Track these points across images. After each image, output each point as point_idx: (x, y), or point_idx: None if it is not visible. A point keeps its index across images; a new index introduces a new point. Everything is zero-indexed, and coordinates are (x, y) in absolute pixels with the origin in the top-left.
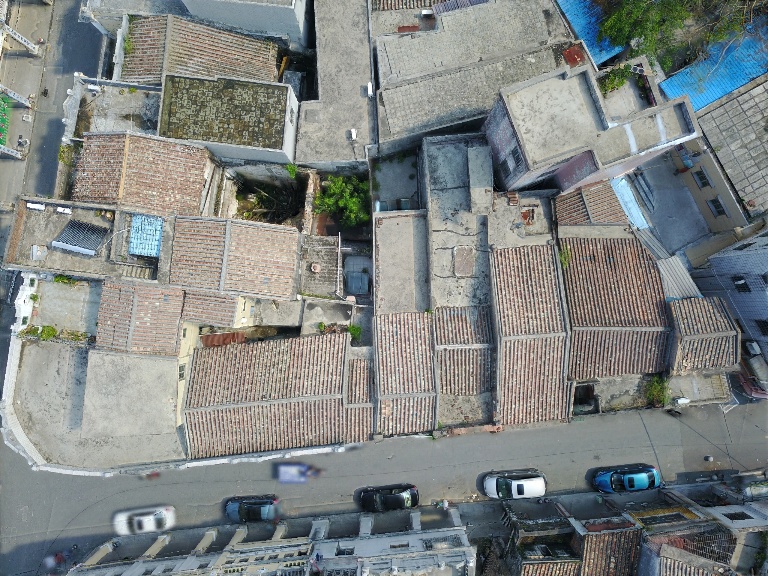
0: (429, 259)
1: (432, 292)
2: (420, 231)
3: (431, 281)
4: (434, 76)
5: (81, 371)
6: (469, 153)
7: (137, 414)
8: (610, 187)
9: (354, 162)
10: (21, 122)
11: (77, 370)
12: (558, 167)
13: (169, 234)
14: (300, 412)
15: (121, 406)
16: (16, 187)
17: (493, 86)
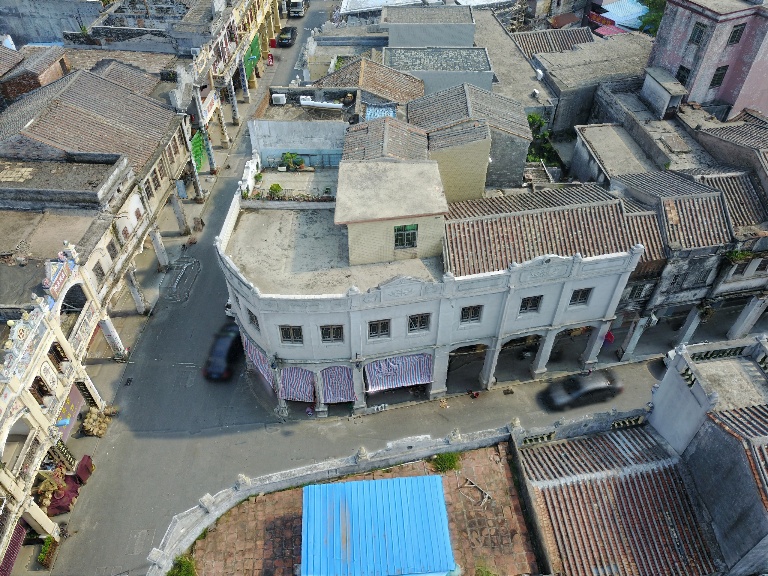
0: (643, 140)
1: (662, 149)
2: (622, 133)
3: (656, 144)
4: (587, 64)
5: (307, 228)
6: (646, 70)
7: (400, 200)
8: (767, 117)
9: (541, 110)
10: (204, 182)
11: (302, 227)
12: (728, 61)
13: (402, 114)
14: (576, 222)
15: (380, 196)
16: (191, 220)
17: (636, 66)
